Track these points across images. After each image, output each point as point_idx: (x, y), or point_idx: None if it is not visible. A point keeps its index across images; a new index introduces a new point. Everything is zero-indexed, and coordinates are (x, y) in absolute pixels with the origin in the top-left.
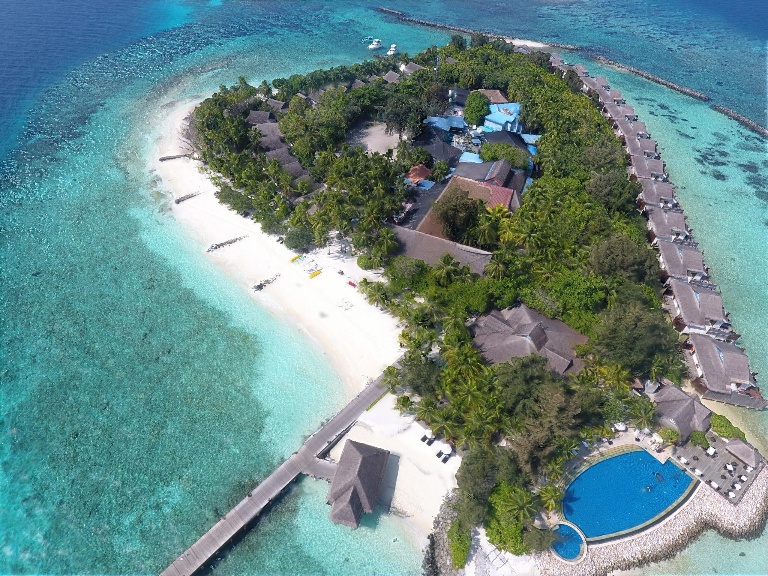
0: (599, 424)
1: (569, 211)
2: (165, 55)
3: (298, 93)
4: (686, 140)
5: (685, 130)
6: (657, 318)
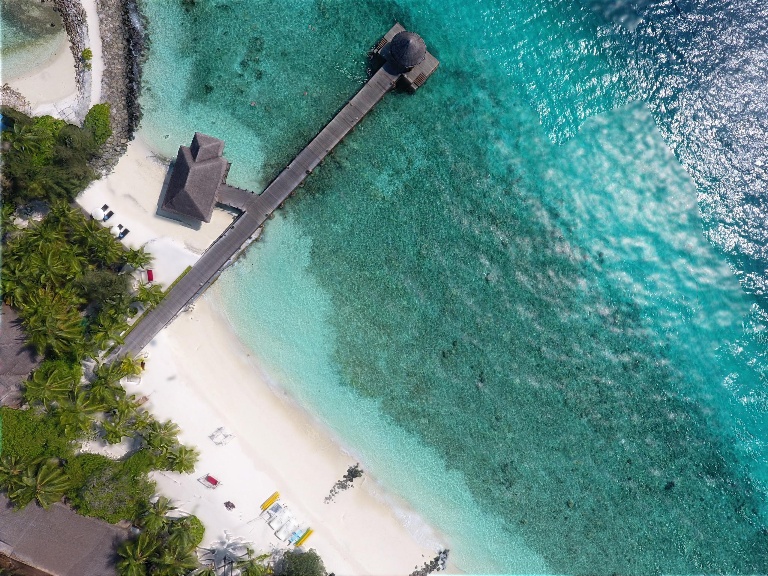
0: None
1: None
2: None
3: None
4: None
5: None
6: None
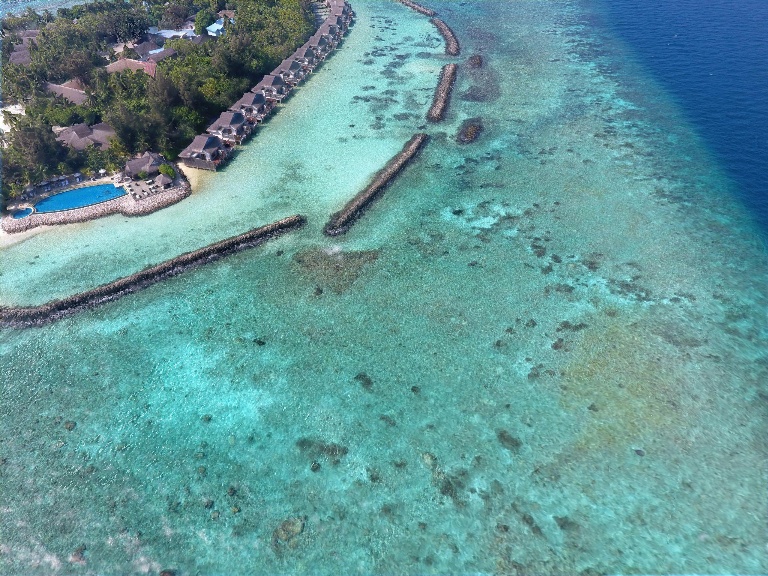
0: (84, 168)
1: None
2: (12, 3)
3: (75, 19)
4: (375, 42)
5: (384, 36)
6: (157, 117)
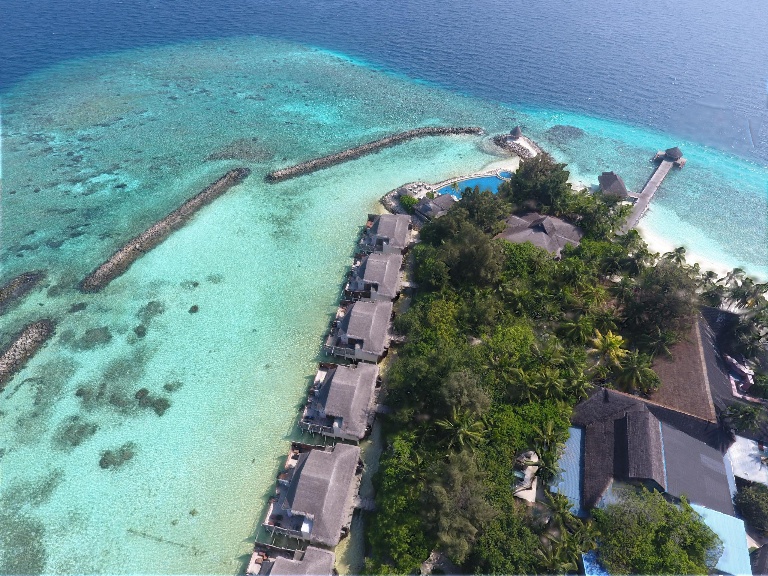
0: None
1: None
2: None
3: None
4: None
5: None
6: None
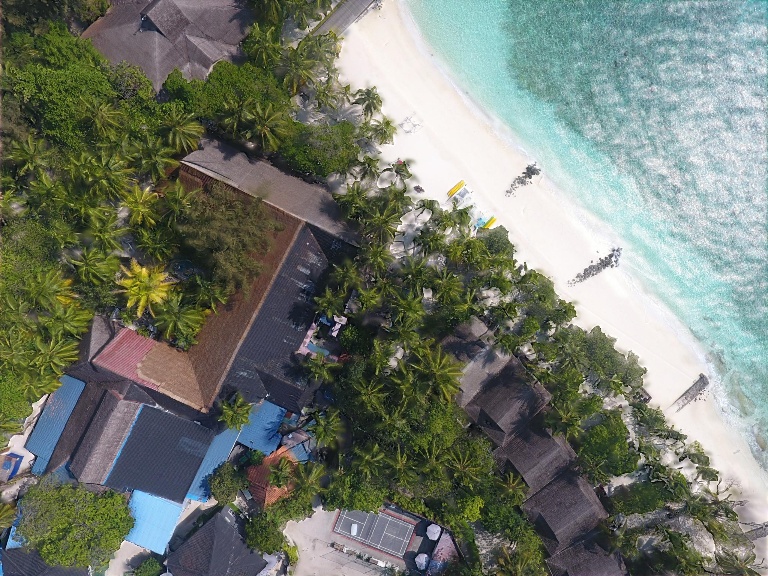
0: None
1: (1, 275)
2: None
3: None
4: None
5: None
6: None
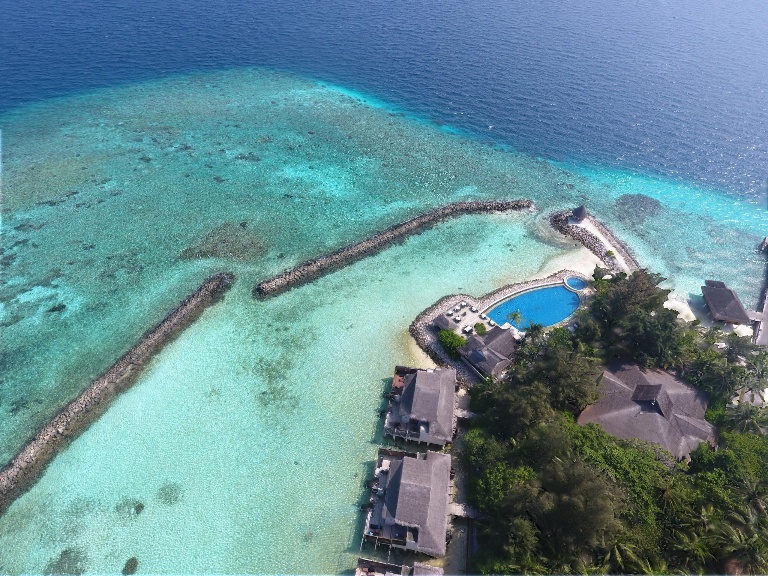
0: None
1: None
2: None
3: None
4: None
5: None
6: None
